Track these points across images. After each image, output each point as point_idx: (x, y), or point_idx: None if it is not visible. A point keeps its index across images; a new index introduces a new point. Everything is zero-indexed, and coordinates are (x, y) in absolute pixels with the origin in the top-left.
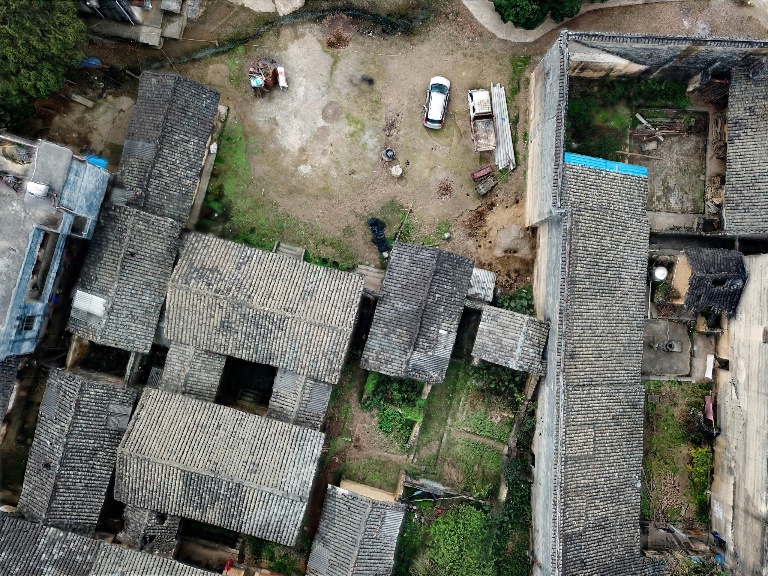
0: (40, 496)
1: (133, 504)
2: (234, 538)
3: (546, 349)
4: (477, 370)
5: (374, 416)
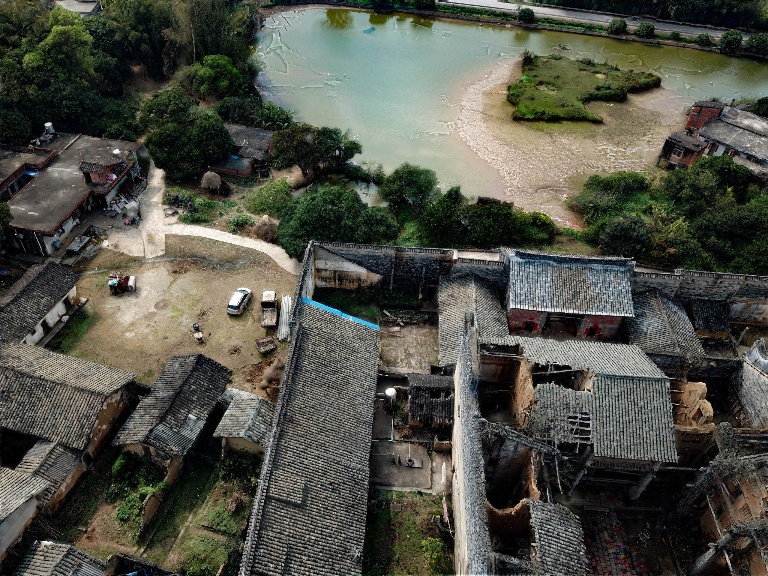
0: None
1: None
2: None
3: None
4: None
5: (116, 506)
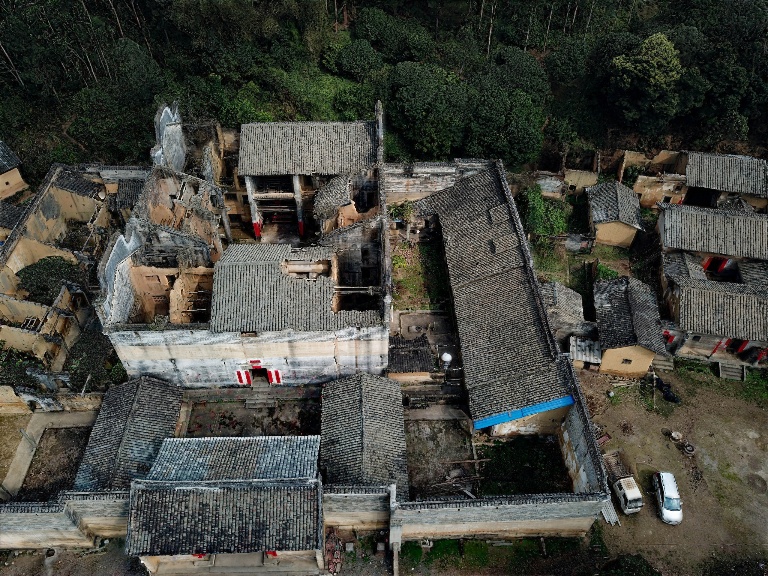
0: None
1: None
2: None
3: None
4: None
5: None
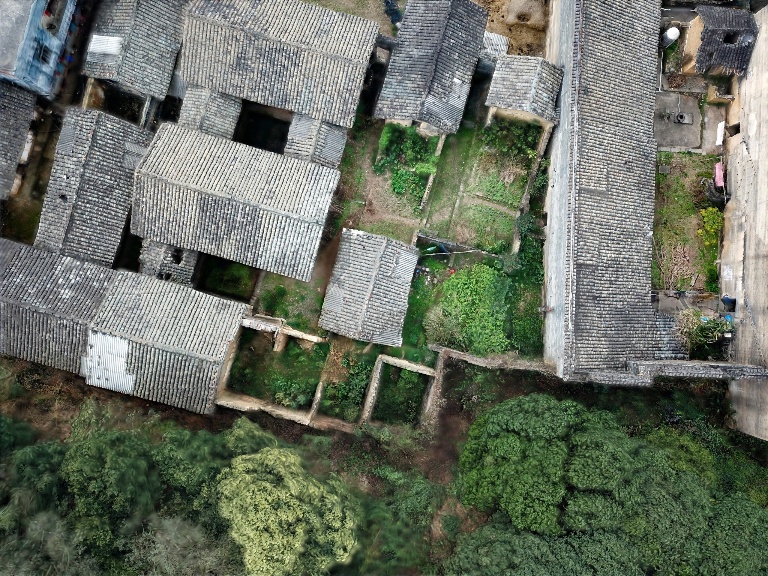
0: (57, 229)
1: (149, 238)
2: (248, 297)
3: (560, 97)
4: (490, 132)
5: (387, 179)
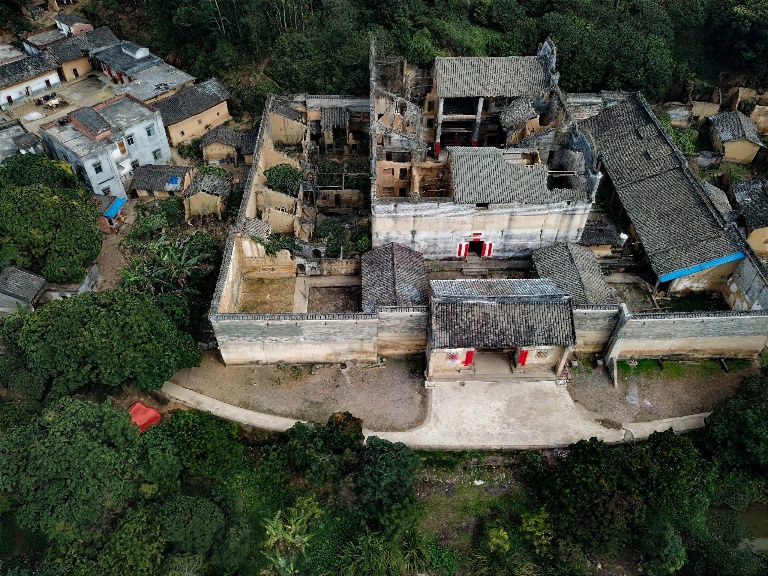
0: None
1: None
2: None
3: None
4: None
5: None
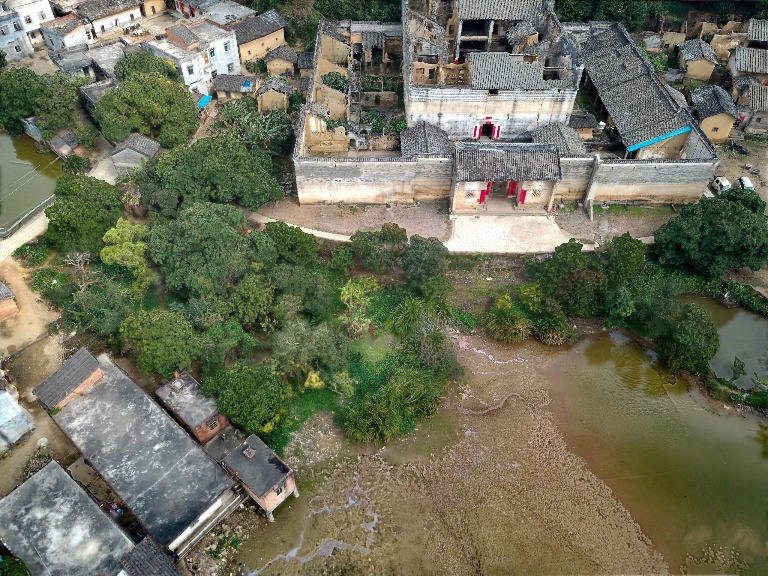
0: None
1: None
2: None
3: None
4: None
5: None
